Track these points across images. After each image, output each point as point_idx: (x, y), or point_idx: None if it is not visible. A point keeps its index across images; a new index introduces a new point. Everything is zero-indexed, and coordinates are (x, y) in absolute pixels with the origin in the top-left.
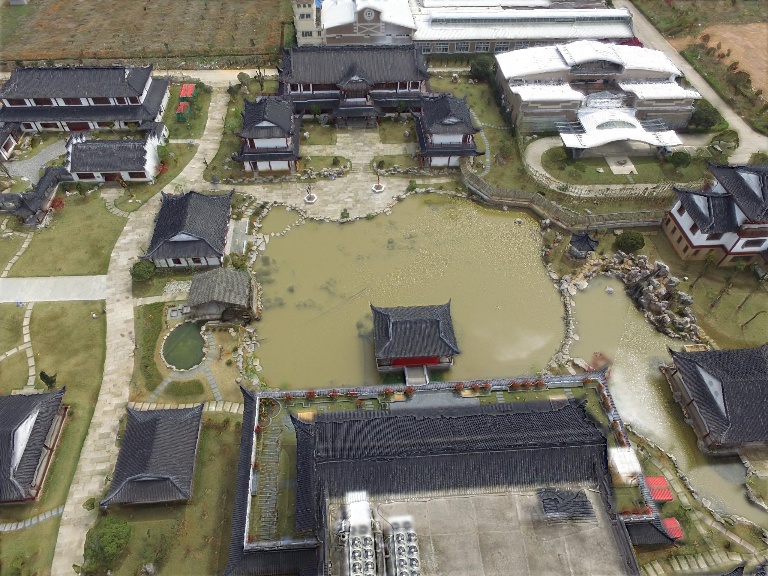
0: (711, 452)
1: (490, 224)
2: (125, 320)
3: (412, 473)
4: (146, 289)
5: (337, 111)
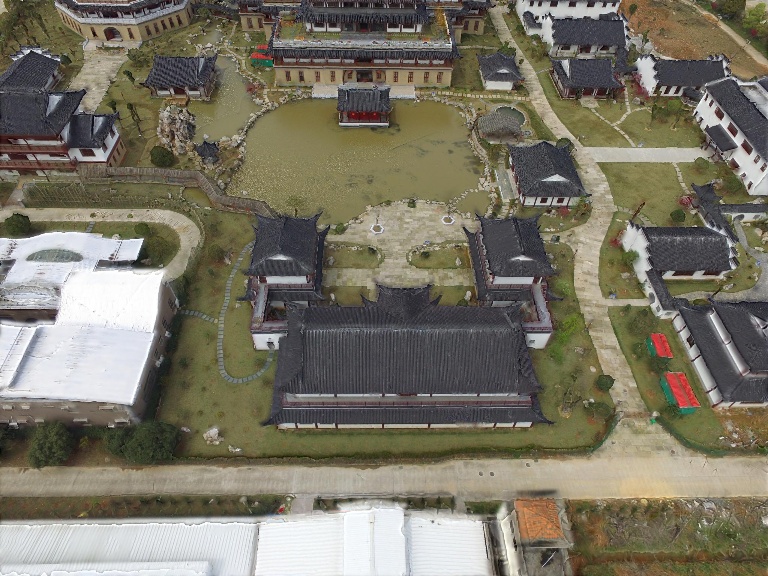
0: None
1: None
2: (560, 135)
3: None
4: None
5: None
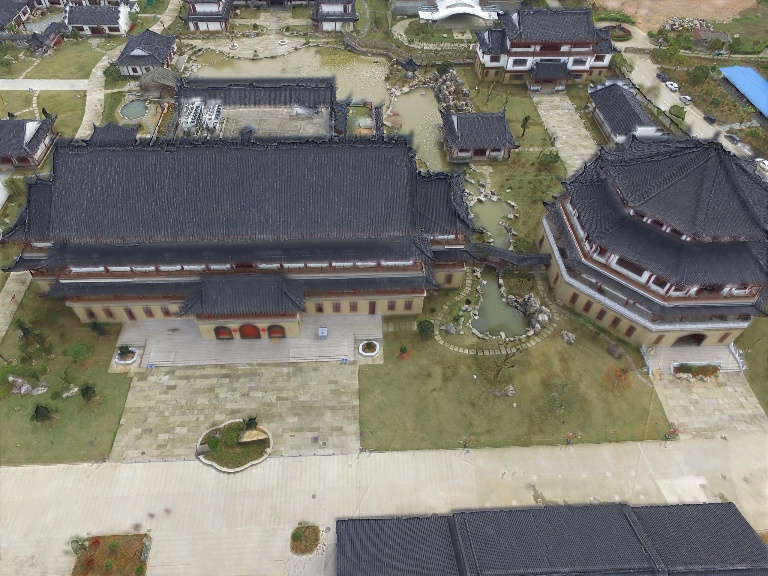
0: (453, 162)
1: (361, 68)
2: (98, 99)
3: (231, 95)
4: (114, 86)
5: None
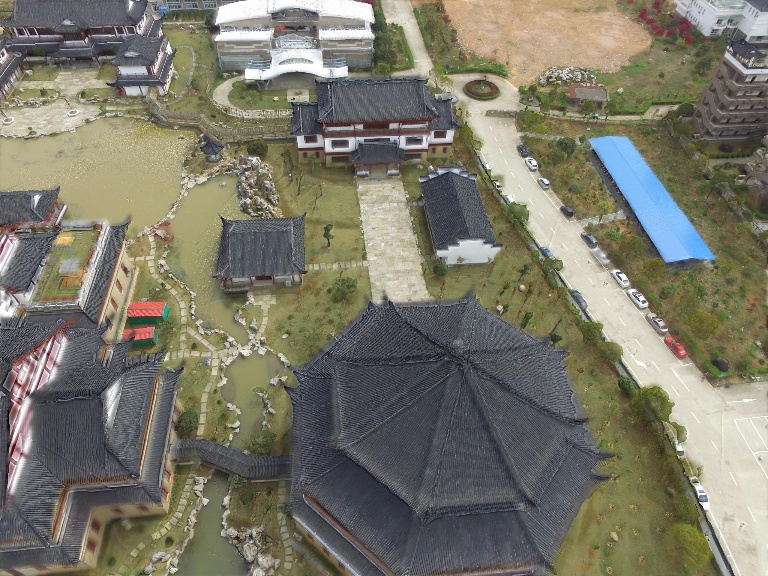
0: (227, 290)
1: (169, 143)
2: None
3: None
4: None
5: (58, 52)
